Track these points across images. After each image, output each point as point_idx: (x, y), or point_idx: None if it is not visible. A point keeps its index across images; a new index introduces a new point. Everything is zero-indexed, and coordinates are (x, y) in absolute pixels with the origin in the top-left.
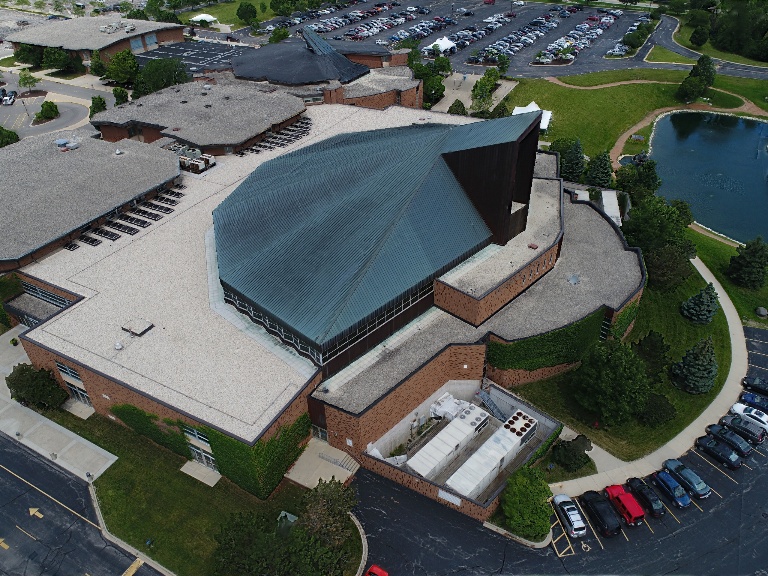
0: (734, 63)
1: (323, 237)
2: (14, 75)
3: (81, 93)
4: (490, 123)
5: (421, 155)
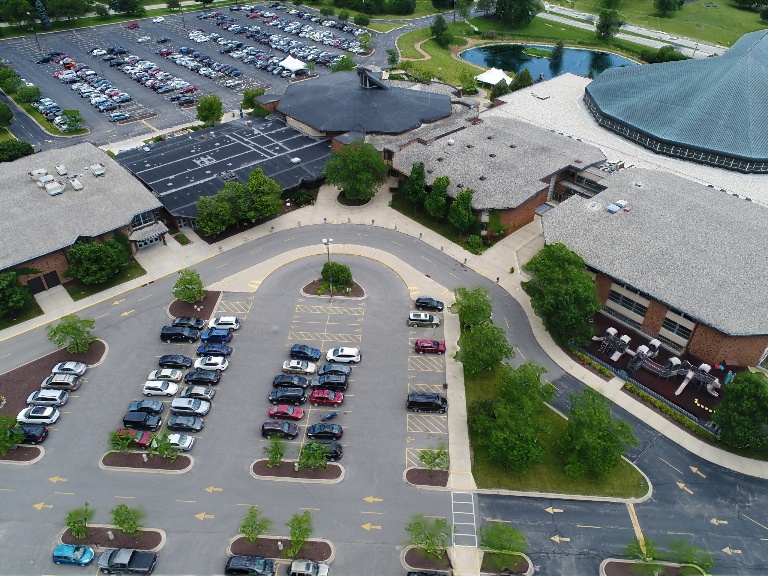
0: (408, 20)
1: None
2: (31, 335)
3: (237, 261)
4: (762, 43)
5: (767, 70)
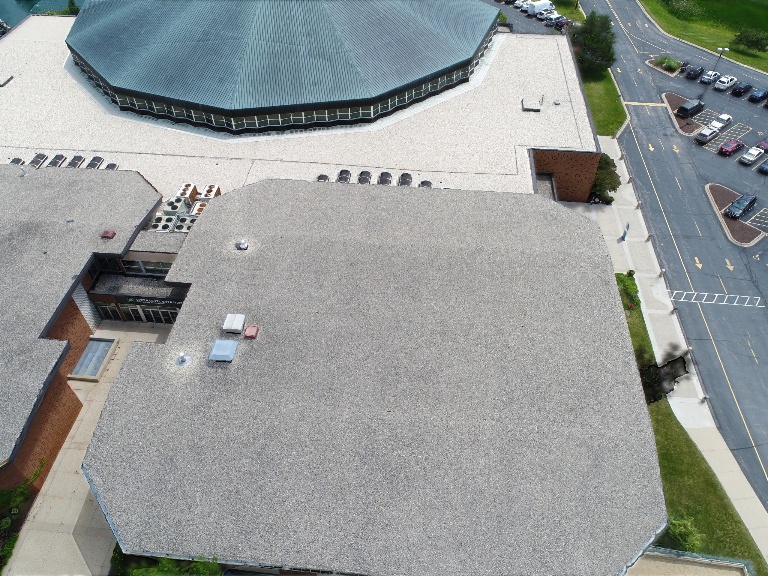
0: None
1: (416, 0)
2: None
3: None
4: None
5: None
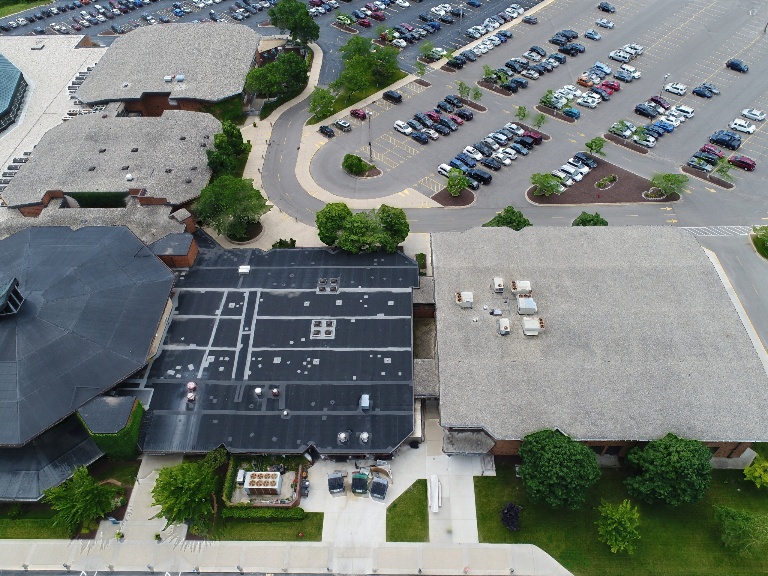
0: None
1: None
2: None
3: None
4: None
5: None
